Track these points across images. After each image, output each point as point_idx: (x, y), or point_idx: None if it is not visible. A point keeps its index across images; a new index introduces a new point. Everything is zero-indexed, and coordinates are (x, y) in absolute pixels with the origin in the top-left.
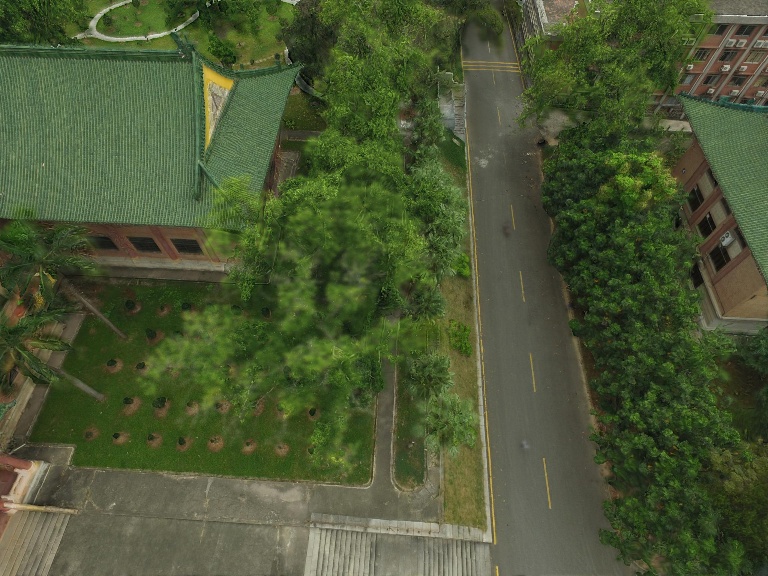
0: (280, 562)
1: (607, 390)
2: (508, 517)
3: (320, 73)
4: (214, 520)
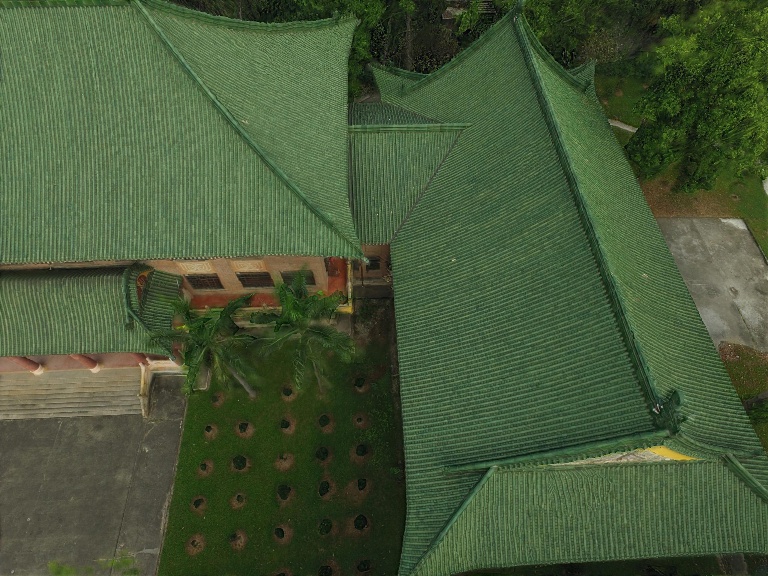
0: None
1: None
2: None
3: None
4: (112, 570)
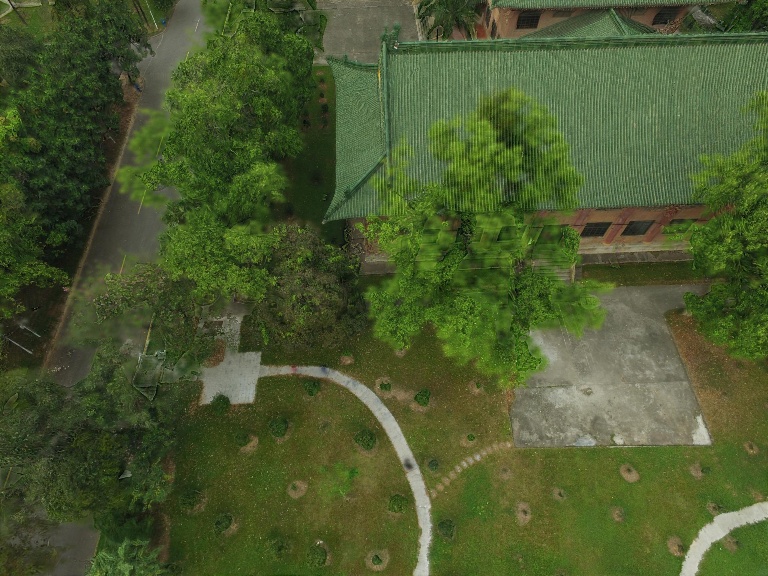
0: (314, 47)
1: (117, 80)
2: None
3: None
4: (349, 53)
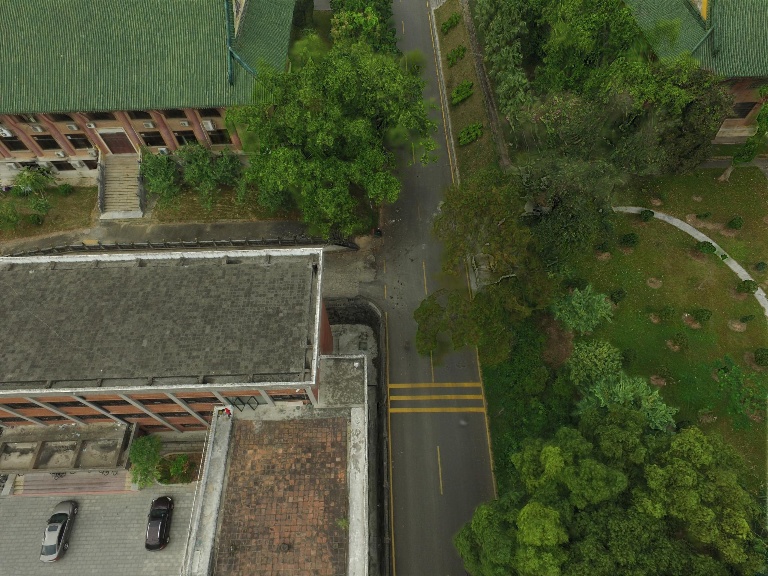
0: None
1: None
2: (423, 18)
3: (653, 110)
4: None
